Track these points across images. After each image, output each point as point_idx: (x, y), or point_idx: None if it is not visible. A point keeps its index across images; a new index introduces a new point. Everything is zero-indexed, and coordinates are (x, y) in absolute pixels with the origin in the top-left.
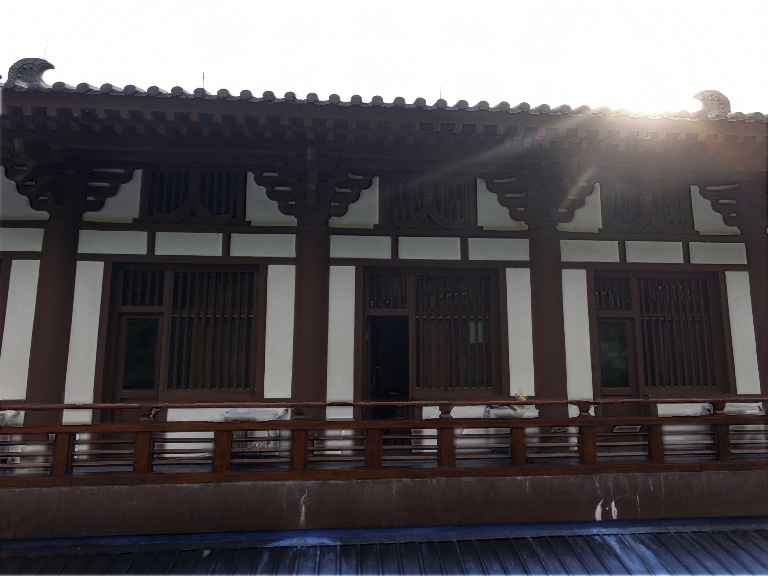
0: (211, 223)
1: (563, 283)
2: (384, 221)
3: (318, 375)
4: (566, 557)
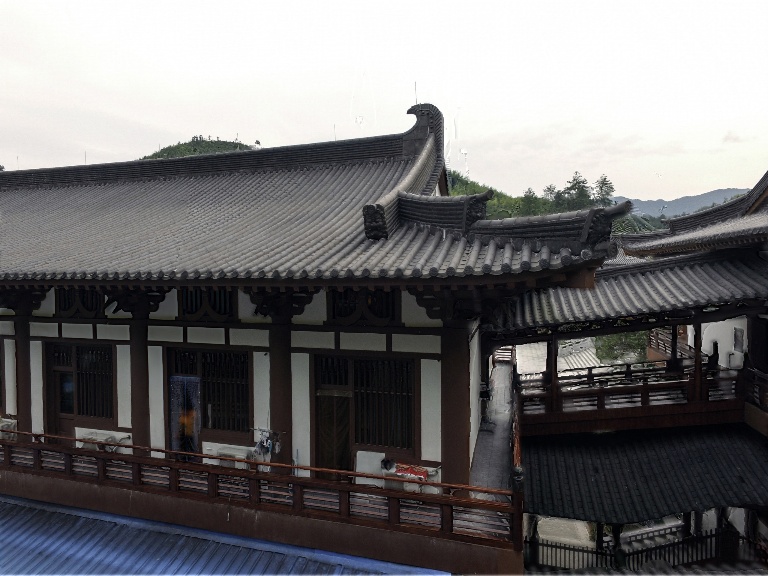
0: None
1: (31, 349)
2: None
3: None
4: None
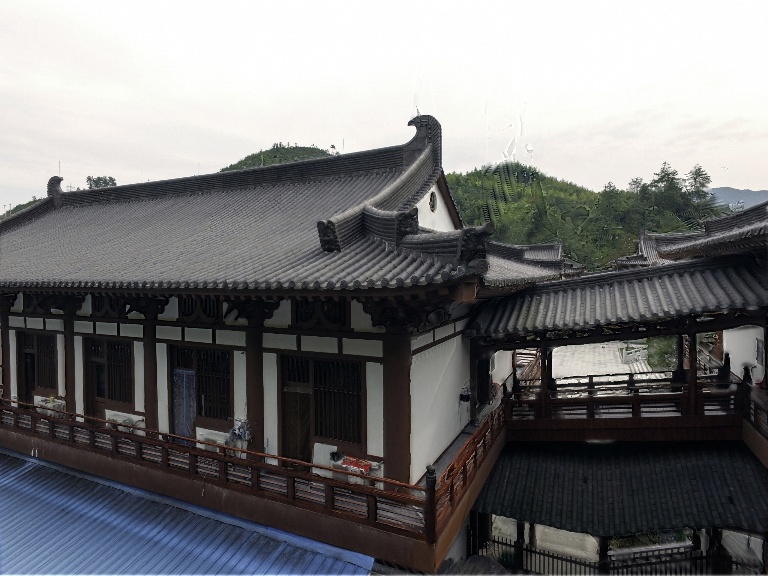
0: None
1: (75, 343)
2: (25, 309)
3: (7, 377)
4: (6, 465)
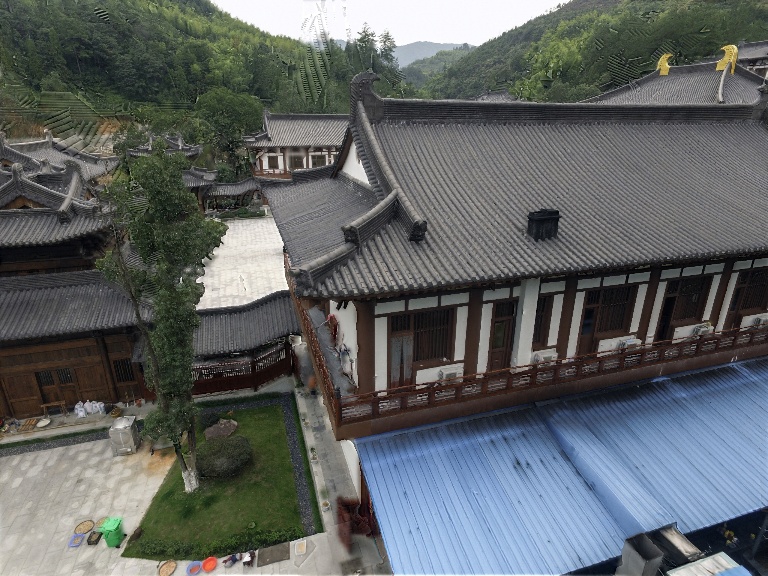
0: (623, 271)
1: None
2: None
3: None
4: (728, 374)
